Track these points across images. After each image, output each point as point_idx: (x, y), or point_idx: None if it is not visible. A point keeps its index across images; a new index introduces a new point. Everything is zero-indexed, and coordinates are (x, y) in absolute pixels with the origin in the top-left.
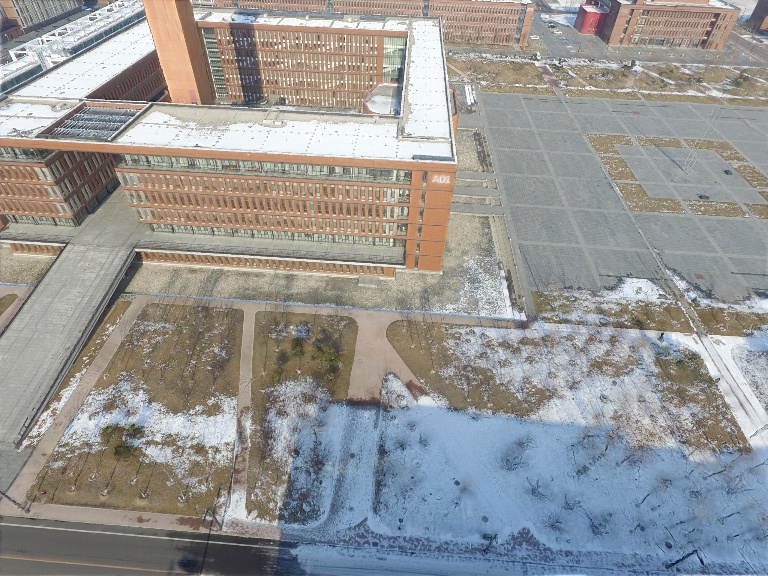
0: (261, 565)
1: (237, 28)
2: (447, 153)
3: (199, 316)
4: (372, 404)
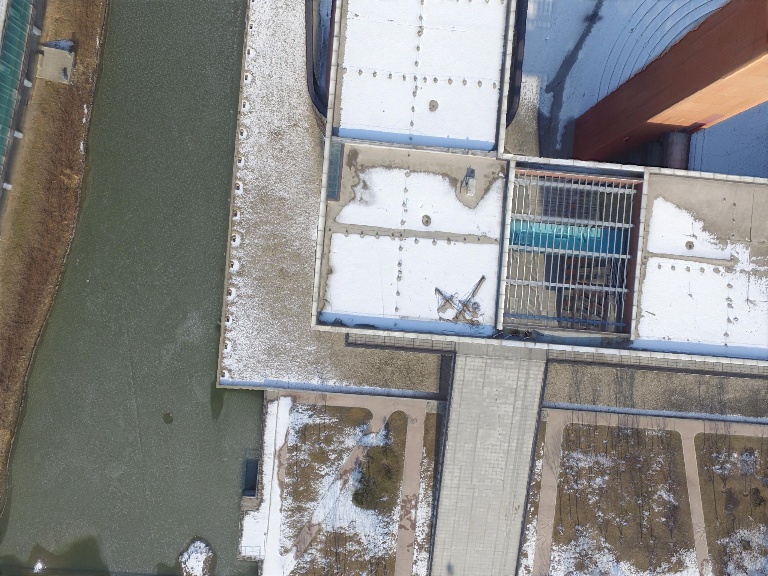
0: None
1: None
2: None
3: (631, 443)
4: None
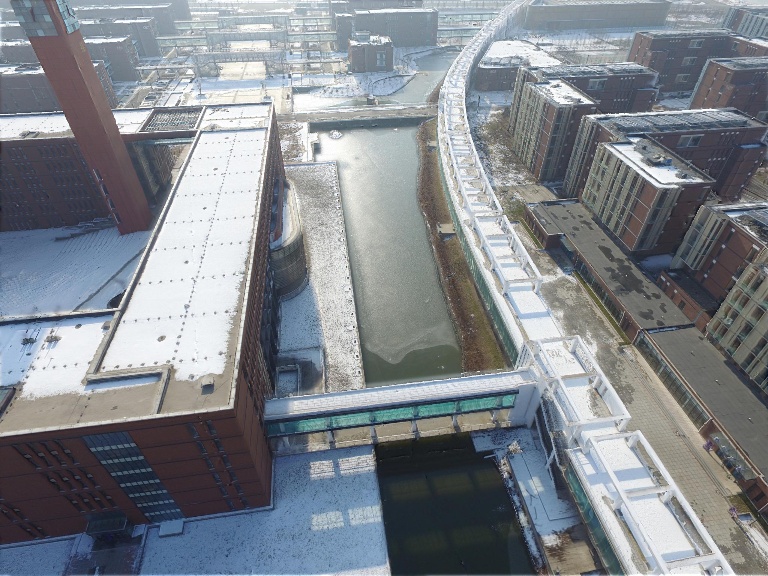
0: None
1: None
2: None
3: None
4: None
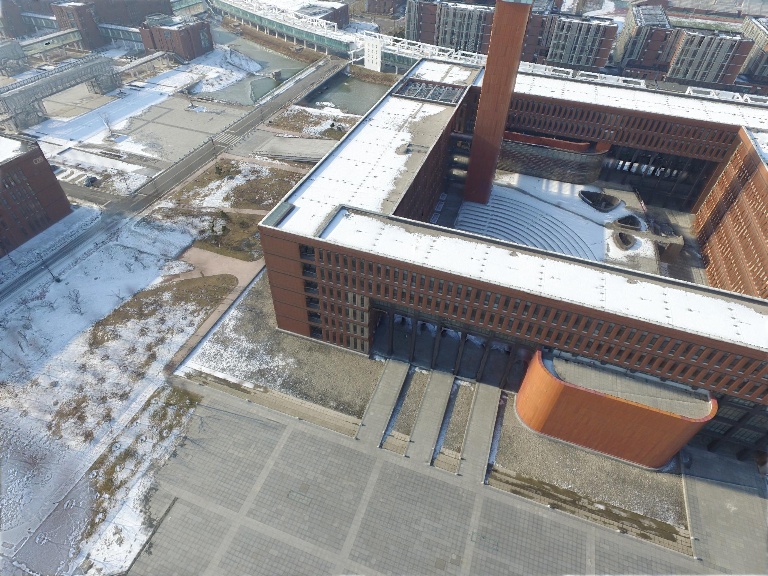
0: (133, 209)
1: (751, 155)
2: (289, 228)
3: None
4: (179, 256)
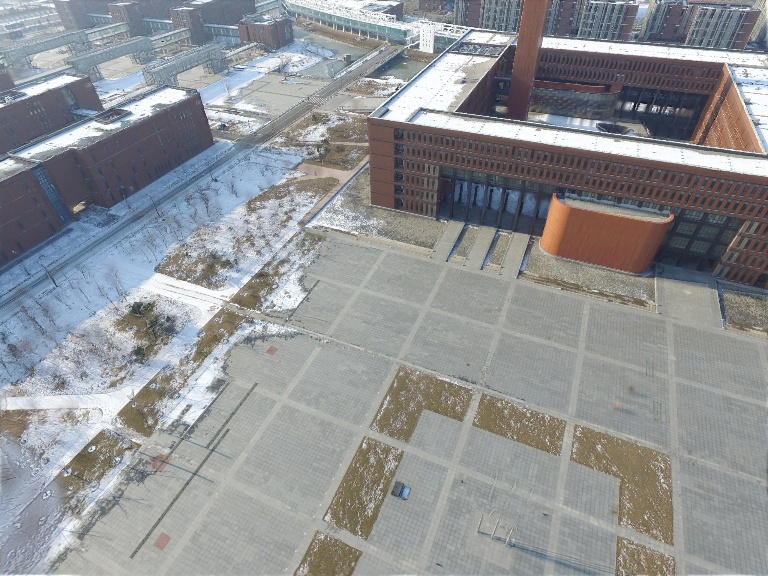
0: None
1: None
2: None
3: None
4: (294, 168)
